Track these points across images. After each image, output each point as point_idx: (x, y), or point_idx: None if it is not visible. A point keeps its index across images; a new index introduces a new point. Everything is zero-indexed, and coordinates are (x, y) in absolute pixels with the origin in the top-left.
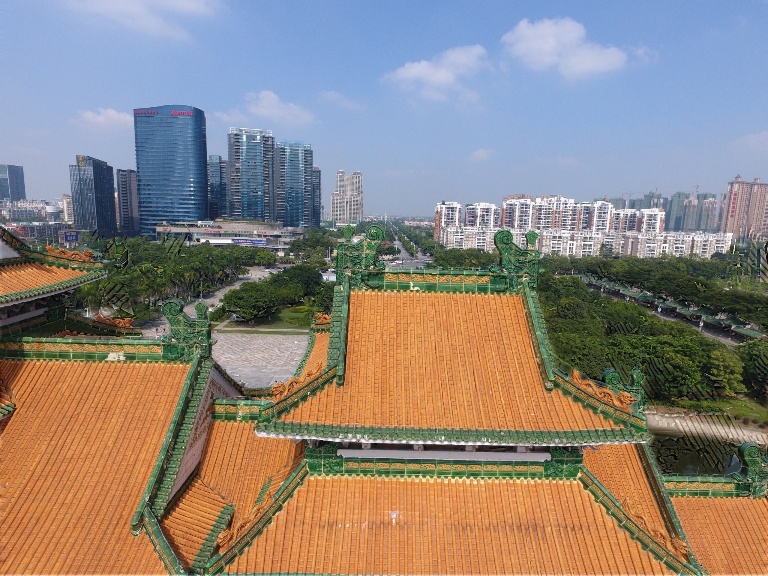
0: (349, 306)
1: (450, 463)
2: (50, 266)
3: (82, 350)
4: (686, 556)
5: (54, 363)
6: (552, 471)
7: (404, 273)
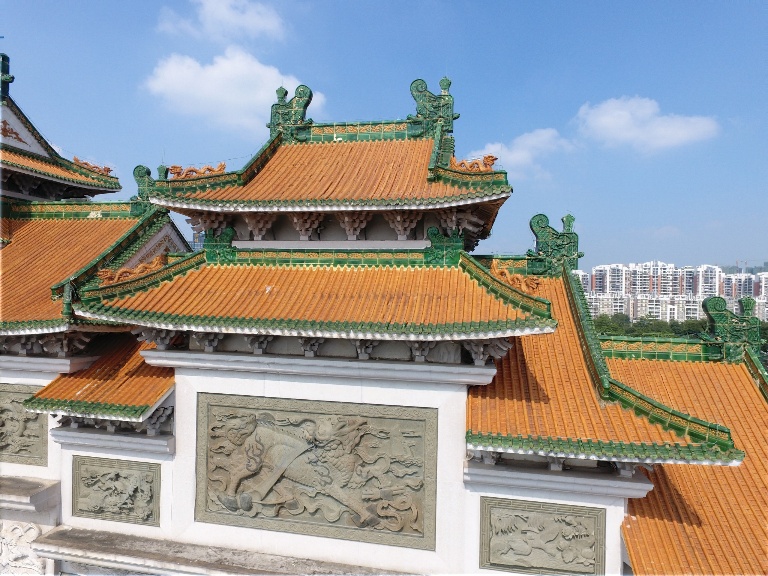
0: (275, 152)
1: (332, 251)
2: (74, 173)
3: (72, 210)
4: (590, 358)
5: (50, 221)
6: (432, 258)
7: (328, 126)
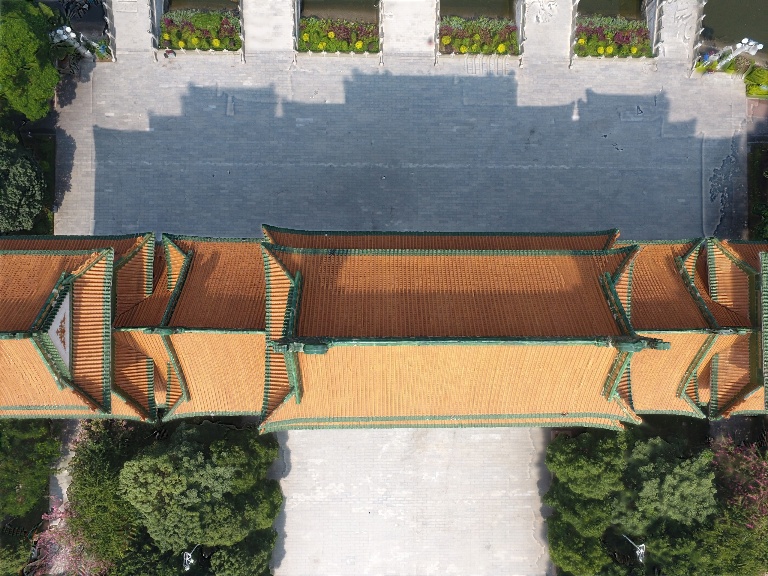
0: None
1: None
2: None
3: None
4: None
5: None
6: None
7: None
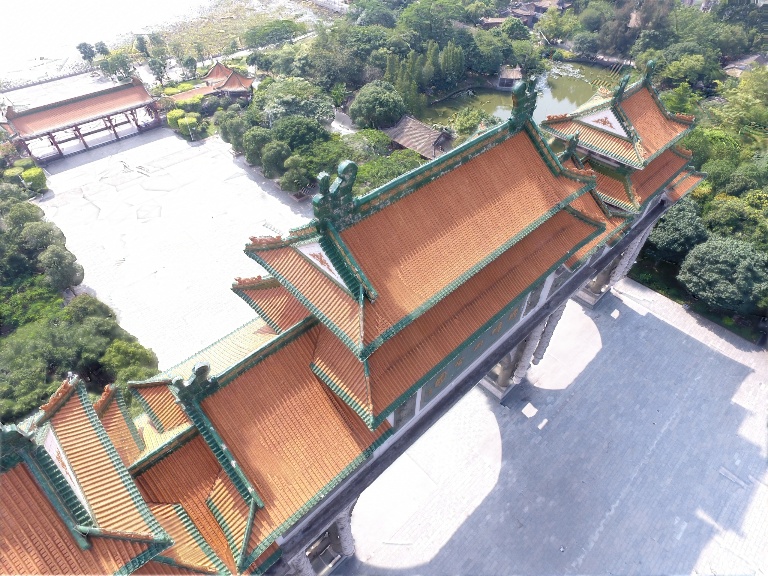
0: None
1: None
2: None
3: None
4: None
5: None
6: None
7: None
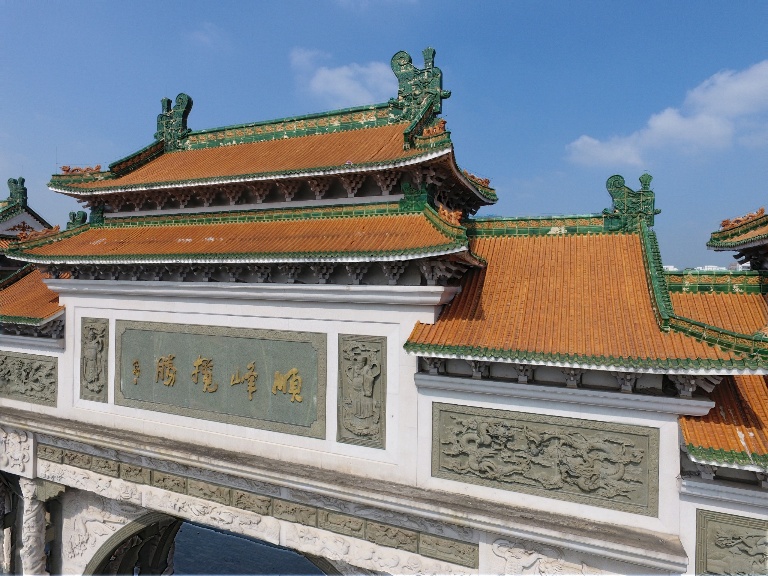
0: None
1: None
2: None
3: (526, 226)
4: None
5: (501, 238)
6: None
7: None
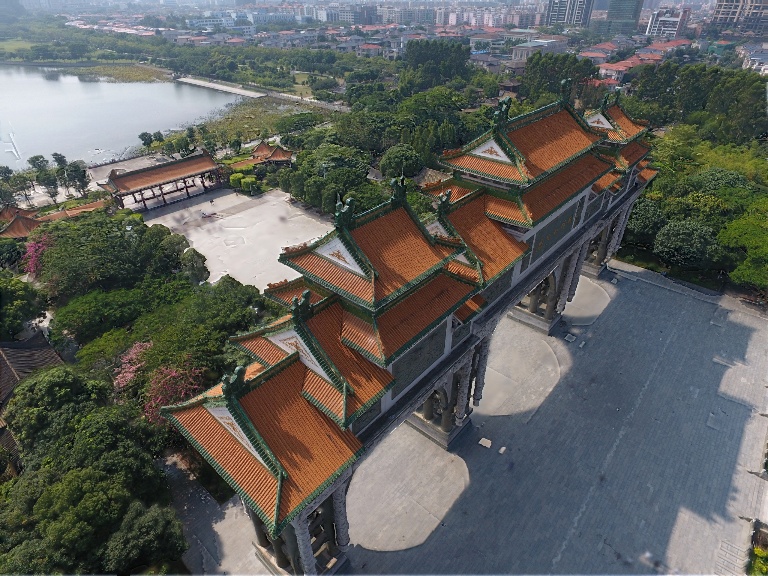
0: None
1: None
2: None
3: None
4: None
5: None
6: None
7: None
